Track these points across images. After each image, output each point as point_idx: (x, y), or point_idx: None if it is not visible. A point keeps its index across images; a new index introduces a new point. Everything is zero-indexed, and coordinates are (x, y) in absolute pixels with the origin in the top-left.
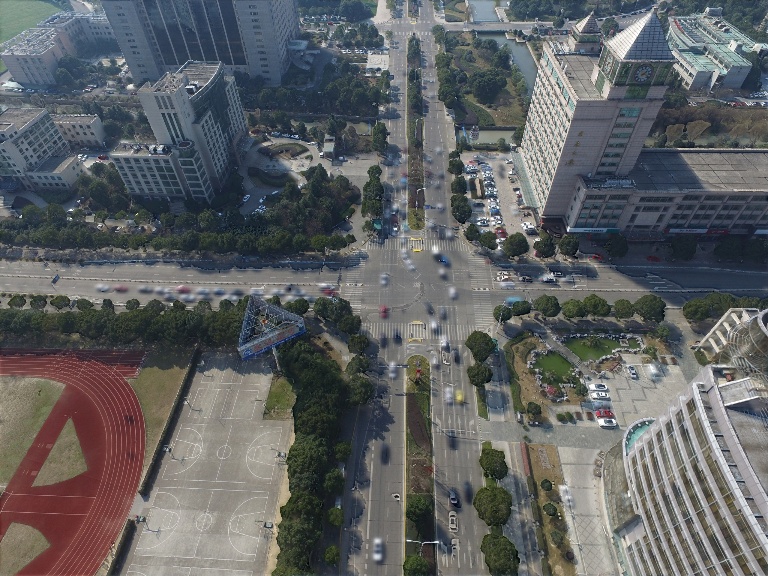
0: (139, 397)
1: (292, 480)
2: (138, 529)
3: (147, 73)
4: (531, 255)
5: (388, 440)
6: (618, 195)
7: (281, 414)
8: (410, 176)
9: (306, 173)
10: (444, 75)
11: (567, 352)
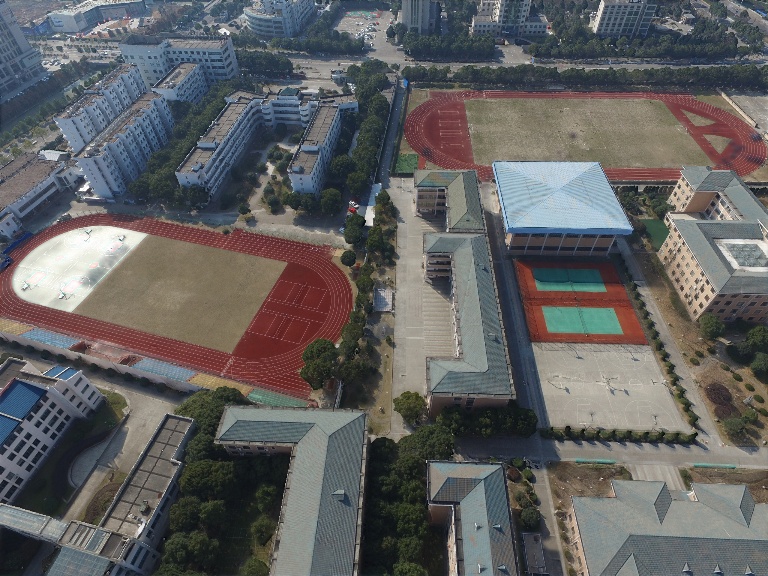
0: (708, 103)
1: None
2: None
3: None
4: None
5: None
6: None
7: None
8: None
9: (698, 24)
10: None
11: None
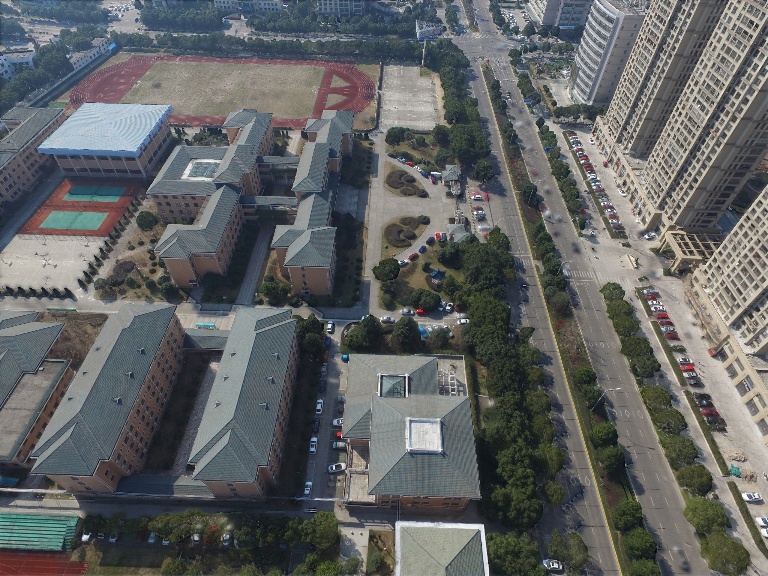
0: None
1: (444, 77)
2: (382, 95)
3: None
4: (536, 40)
5: (477, 81)
6: (579, 4)
7: (428, 75)
8: (467, 16)
9: (413, 7)
10: None
11: (554, 63)
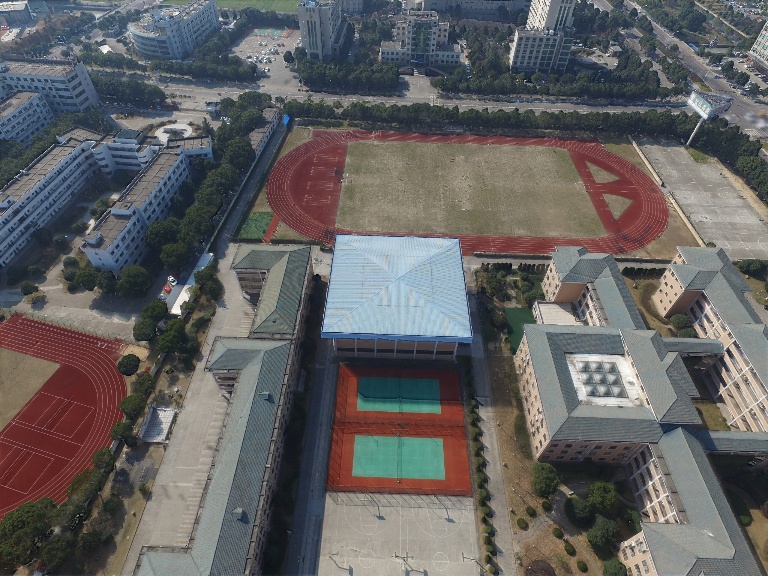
0: (616, 154)
1: None
2: None
3: (436, 5)
4: None
5: None
6: None
7: (705, 161)
8: None
9: (622, 59)
10: (661, 12)
11: None
